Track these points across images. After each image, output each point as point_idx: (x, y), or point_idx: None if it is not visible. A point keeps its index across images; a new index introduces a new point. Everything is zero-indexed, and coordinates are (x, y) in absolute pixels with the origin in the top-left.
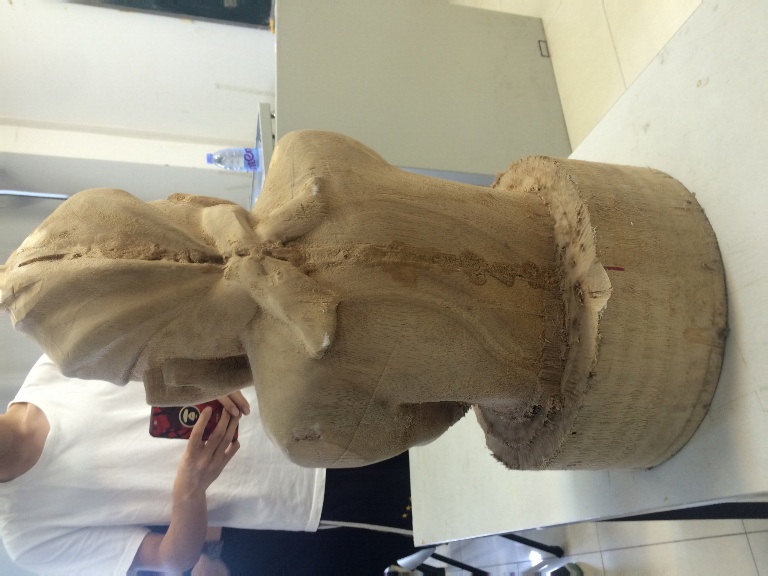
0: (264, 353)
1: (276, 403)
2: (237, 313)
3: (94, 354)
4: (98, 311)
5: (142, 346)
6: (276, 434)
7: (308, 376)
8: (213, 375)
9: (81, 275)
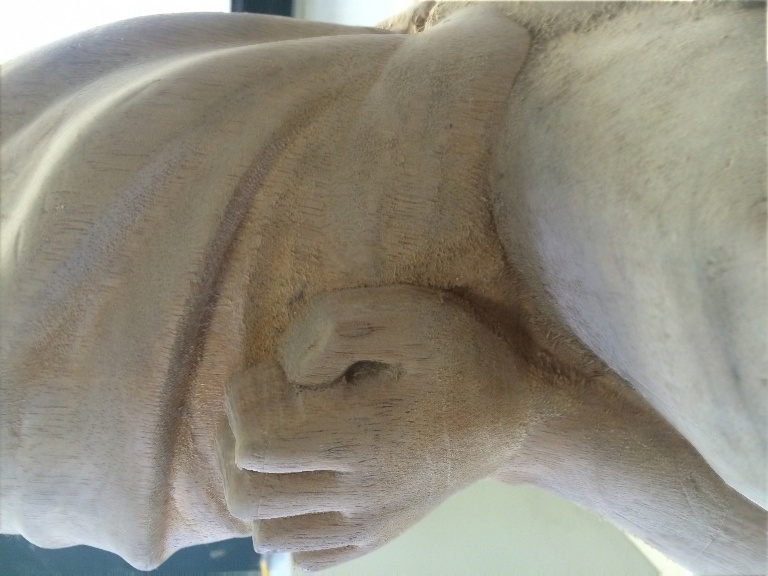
0: (592, 90)
1: (709, 128)
2: (485, 51)
3: (98, 223)
4: (130, 78)
5: (241, 186)
6: (763, 211)
7: (764, 35)
8: (434, 307)
9: (95, 27)
